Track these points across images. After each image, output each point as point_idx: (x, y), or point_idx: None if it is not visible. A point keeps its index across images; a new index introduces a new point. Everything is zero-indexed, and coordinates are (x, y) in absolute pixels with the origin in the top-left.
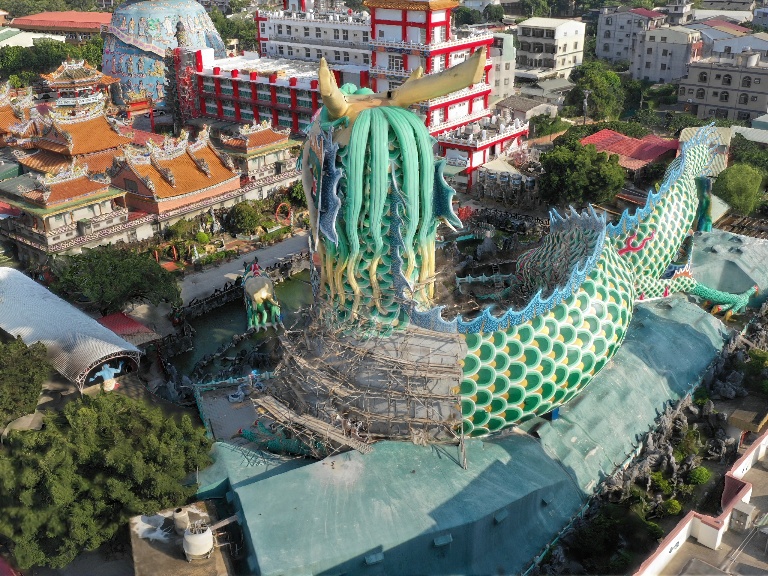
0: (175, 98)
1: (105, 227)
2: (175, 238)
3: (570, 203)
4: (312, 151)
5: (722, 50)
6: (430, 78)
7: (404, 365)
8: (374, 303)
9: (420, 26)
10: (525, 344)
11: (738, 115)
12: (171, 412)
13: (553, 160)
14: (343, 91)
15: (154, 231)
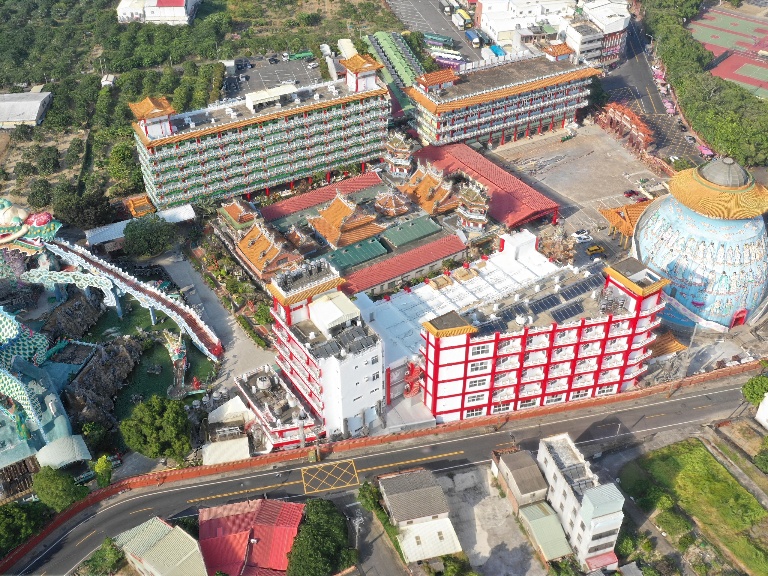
0: None
1: None
2: None
3: None
4: None
5: None
6: None
7: None
8: None
9: None
10: None
11: None
12: None
13: None
14: (2, 200)
15: None
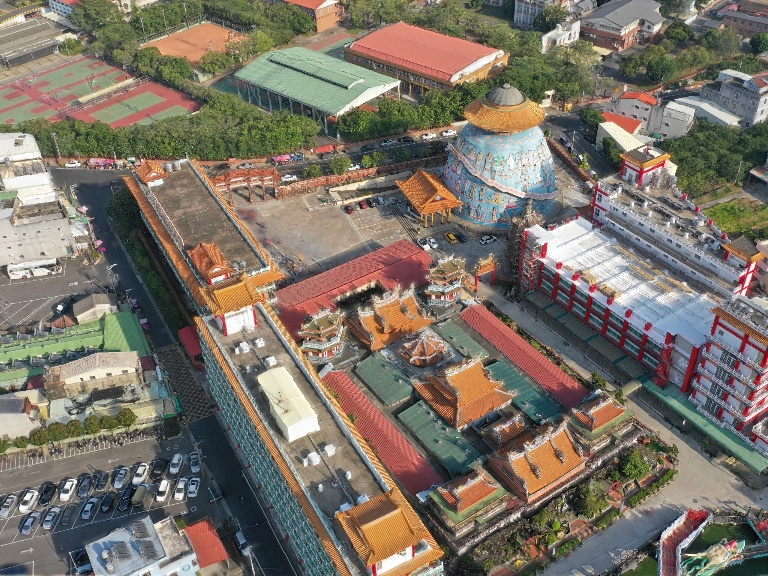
0: (516, 264)
1: (490, 515)
2: None
3: None
4: None
5: None
6: None
7: None
8: None
9: (759, 350)
10: None
11: None
12: None
13: None
14: None
15: (521, 511)
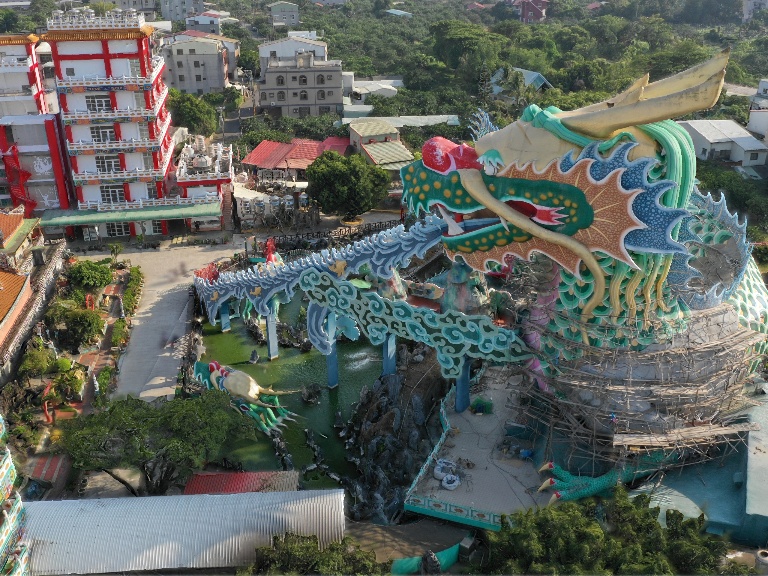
0: None
1: None
2: (25, 381)
3: (364, 208)
4: (532, 181)
5: (268, 55)
6: (667, 83)
7: (725, 344)
8: (657, 305)
9: (129, 57)
10: (753, 293)
11: (319, 110)
12: (424, 533)
13: (331, 172)
14: None
15: None
